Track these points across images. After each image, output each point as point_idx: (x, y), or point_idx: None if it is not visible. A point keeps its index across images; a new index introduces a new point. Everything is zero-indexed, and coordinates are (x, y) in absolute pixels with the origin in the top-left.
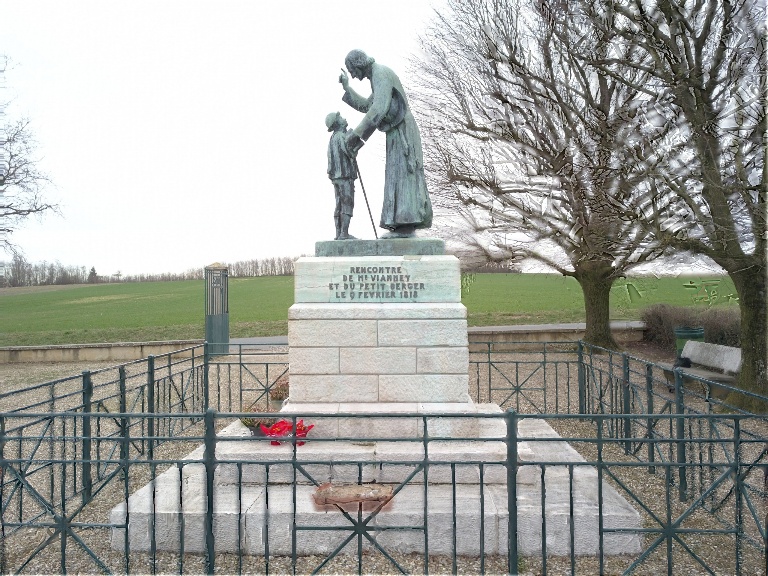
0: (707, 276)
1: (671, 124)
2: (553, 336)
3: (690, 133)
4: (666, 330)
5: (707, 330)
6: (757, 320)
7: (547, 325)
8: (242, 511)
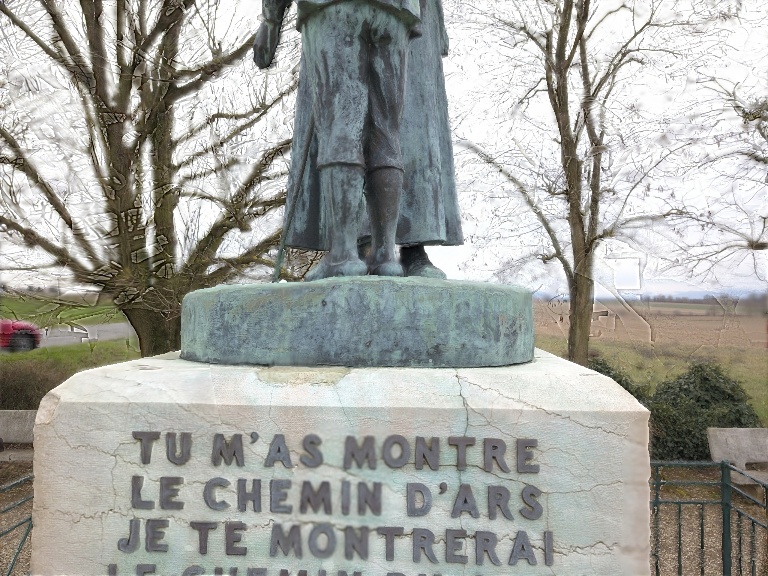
0: None
1: (204, 124)
2: None
3: None
4: None
5: None
6: None
7: None
8: None
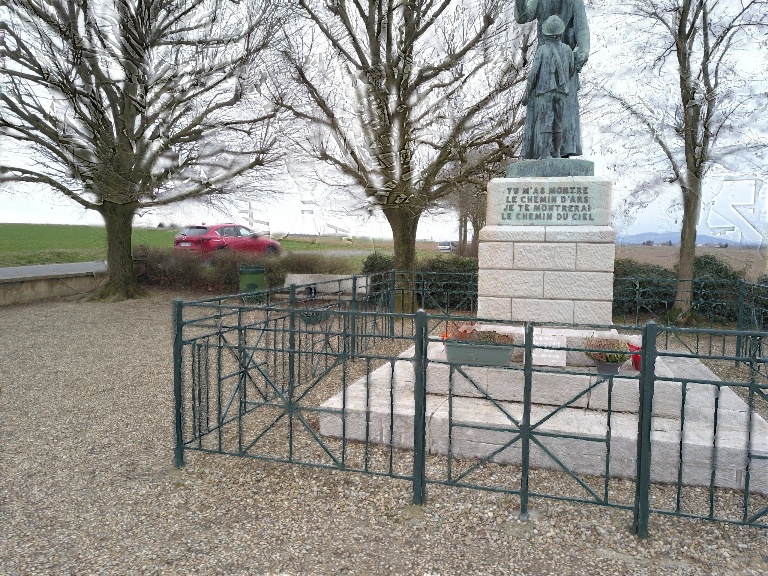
0: (222, 218)
1: (445, 99)
2: (50, 283)
3: (453, 111)
4: (170, 270)
5: (224, 267)
6: (409, 252)
7: (43, 270)
8: (754, 413)
